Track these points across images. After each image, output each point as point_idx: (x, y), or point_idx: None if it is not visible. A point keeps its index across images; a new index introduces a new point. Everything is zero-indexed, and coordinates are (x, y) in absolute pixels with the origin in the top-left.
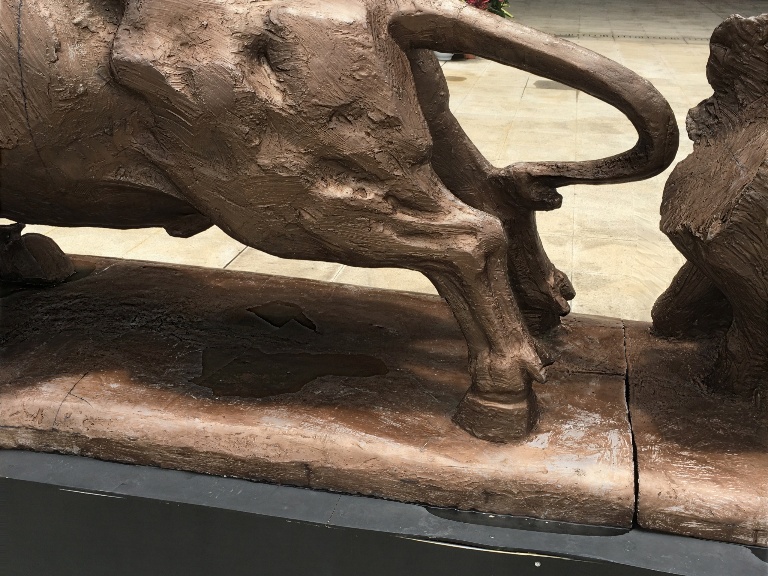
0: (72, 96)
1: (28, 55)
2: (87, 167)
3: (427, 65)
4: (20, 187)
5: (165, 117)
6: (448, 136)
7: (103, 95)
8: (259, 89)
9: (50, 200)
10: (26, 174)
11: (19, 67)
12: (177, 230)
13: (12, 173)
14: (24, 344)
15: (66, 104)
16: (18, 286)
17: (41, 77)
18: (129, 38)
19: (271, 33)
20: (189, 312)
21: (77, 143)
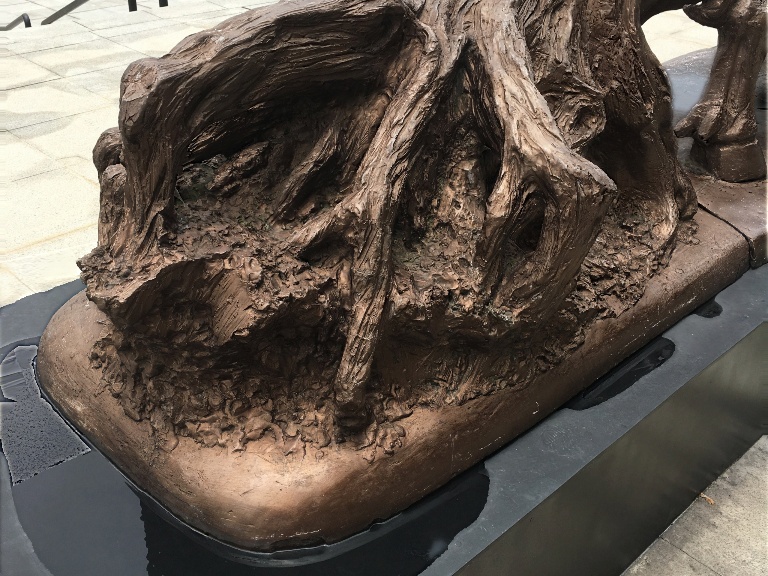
0: None
1: None
2: None
3: None
4: None
5: None
6: None
7: None
8: None
9: None
10: None
11: None
12: None
13: None
14: None
15: None
16: None
17: None
18: None
19: None
20: None
21: None
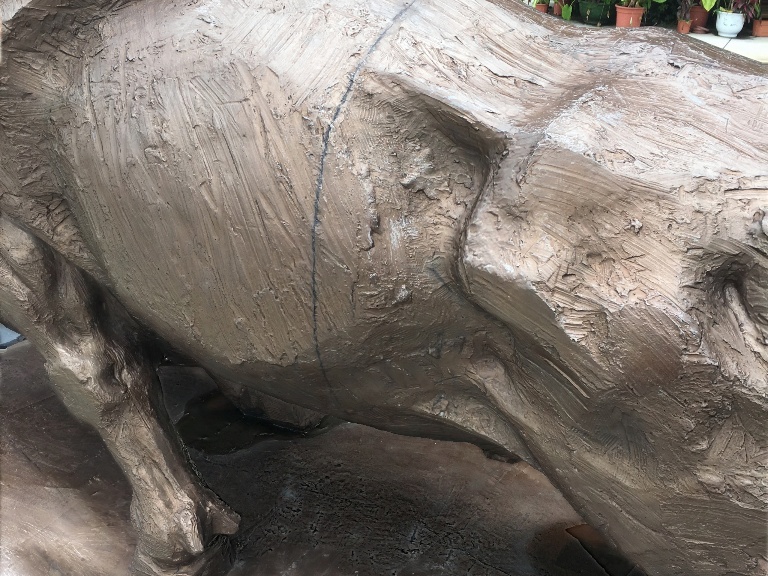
0: (388, 303)
1: (328, 235)
2: (392, 392)
3: None
4: (289, 397)
5: (539, 365)
6: None
7: (435, 302)
8: (725, 356)
9: (328, 413)
10: (301, 390)
11: (312, 251)
12: (500, 455)
13: (281, 386)
14: (267, 560)
15: (377, 314)
16: (263, 427)
17: (344, 271)
18: (496, 230)
19: (760, 254)
20: (487, 527)
21: (383, 363)
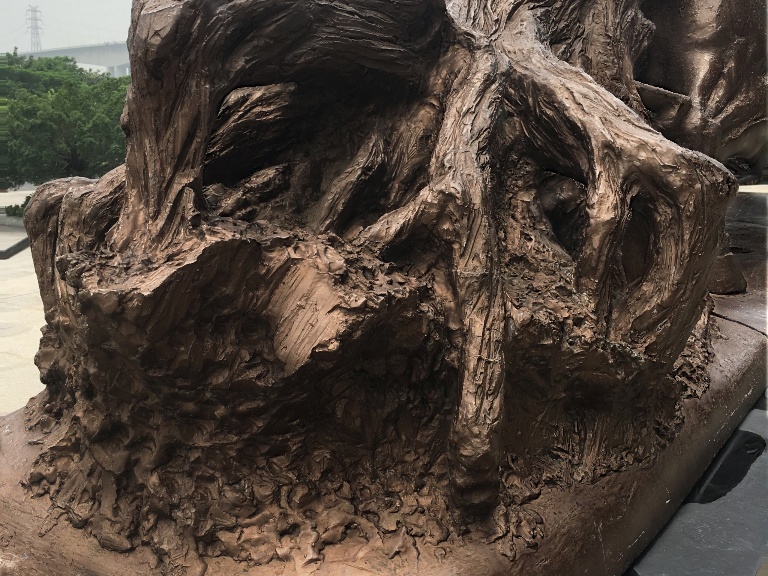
0: None
1: None
2: None
3: (686, 11)
4: None
5: None
6: (685, 73)
7: None
8: None
9: None
10: None
11: None
12: None
13: None
14: None
15: None
16: None
17: None
18: None
19: None
20: None
21: None
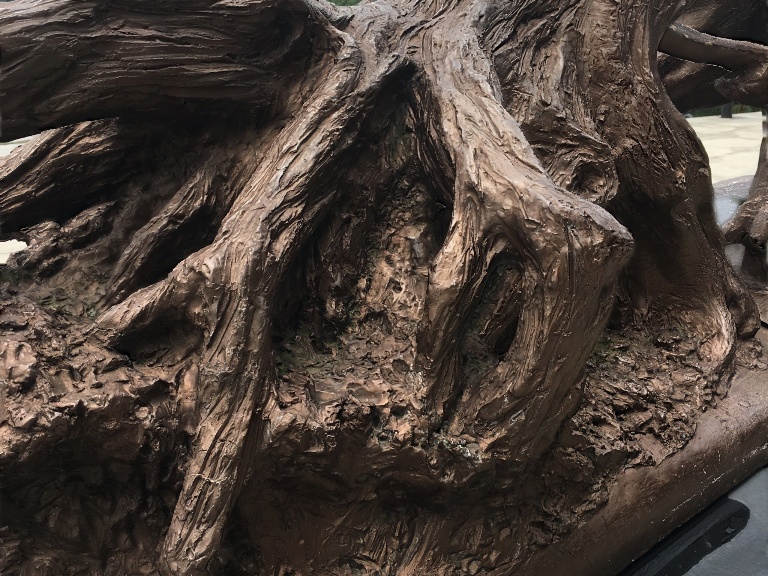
0: None
1: None
2: None
3: None
4: None
5: None
6: None
7: None
8: None
9: None
10: None
11: None
12: None
13: None
14: None
15: None
16: None
17: None
18: None
19: None
20: None
21: None
